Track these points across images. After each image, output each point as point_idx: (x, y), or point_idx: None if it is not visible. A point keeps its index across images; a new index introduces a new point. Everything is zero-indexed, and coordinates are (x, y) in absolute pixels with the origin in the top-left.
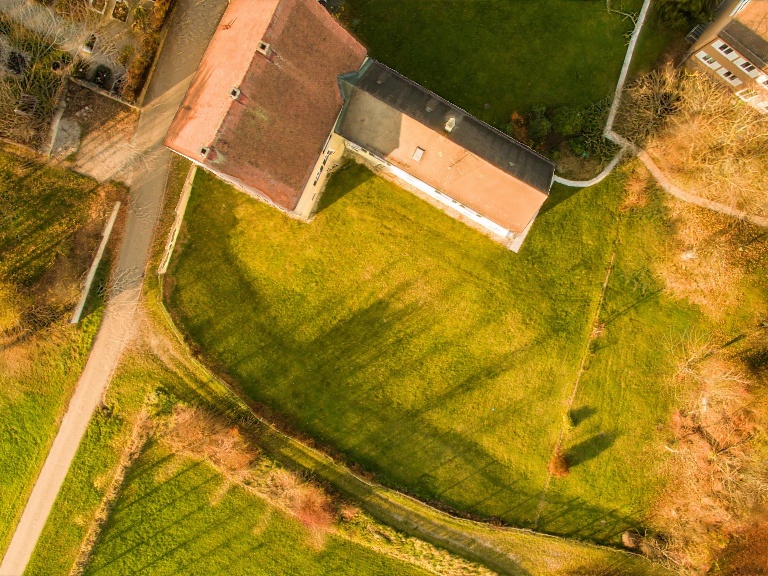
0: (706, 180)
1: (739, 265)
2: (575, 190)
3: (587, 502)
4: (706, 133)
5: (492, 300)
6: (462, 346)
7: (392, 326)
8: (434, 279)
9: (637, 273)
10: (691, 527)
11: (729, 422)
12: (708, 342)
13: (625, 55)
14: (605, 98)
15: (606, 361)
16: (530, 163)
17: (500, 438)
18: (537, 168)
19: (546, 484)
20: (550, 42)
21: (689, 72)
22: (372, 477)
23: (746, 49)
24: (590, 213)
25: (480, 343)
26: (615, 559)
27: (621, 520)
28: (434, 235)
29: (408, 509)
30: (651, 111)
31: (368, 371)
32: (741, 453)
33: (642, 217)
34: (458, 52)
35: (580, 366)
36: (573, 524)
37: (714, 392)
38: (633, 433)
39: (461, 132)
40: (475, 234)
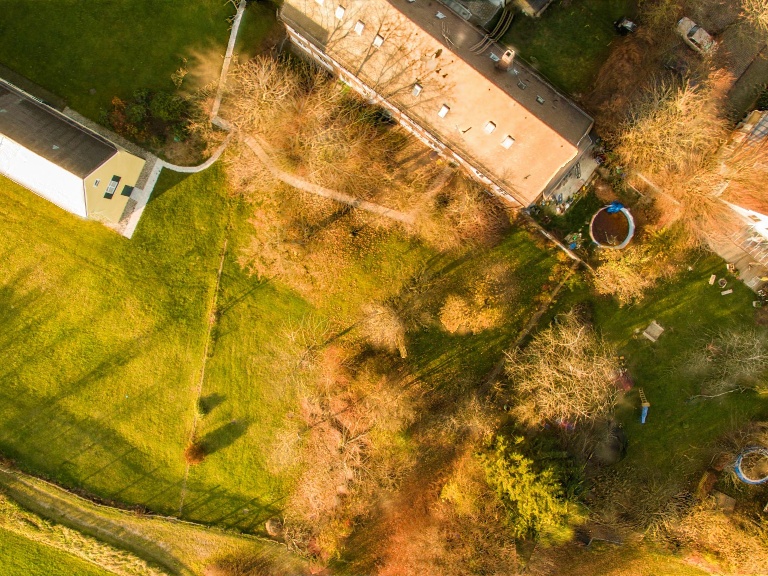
0: (312, 165)
1: (350, 251)
2: (184, 176)
3: (228, 490)
4: (313, 118)
5: (110, 286)
6: (88, 333)
7: (20, 312)
8: (52, 265)
9: (251, 259)
10: (328, 516)
11: (355, 410)
12: (327, 329)
13: (228, 40)
14: (210, 83)
15: (229, 348)
16: (83, 147)
17: (136, 425)
18: (90, 152)
19: (186, 472)
20: (153, 27)
21: (294, 57)
22: (10, 464)
23: (304, 32)
24: (201, 199)
25: (105, 330)
26: (261, 548)
27: (263, 508)
28: (48, 221)
29: (54, 496)
30: (256, 96)
31: (2, 358)
32: (369, 441)
33: (252, 203)
34: (62, 37)
35: (204, 353)
36: (217, 512)
37: (334, 379)
38: (265, 421)
39: (5, 115)
40: (88, 220)
